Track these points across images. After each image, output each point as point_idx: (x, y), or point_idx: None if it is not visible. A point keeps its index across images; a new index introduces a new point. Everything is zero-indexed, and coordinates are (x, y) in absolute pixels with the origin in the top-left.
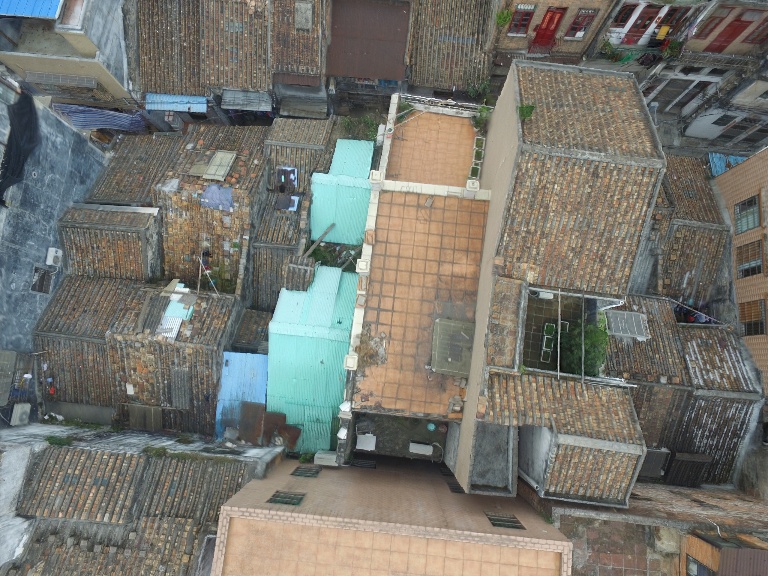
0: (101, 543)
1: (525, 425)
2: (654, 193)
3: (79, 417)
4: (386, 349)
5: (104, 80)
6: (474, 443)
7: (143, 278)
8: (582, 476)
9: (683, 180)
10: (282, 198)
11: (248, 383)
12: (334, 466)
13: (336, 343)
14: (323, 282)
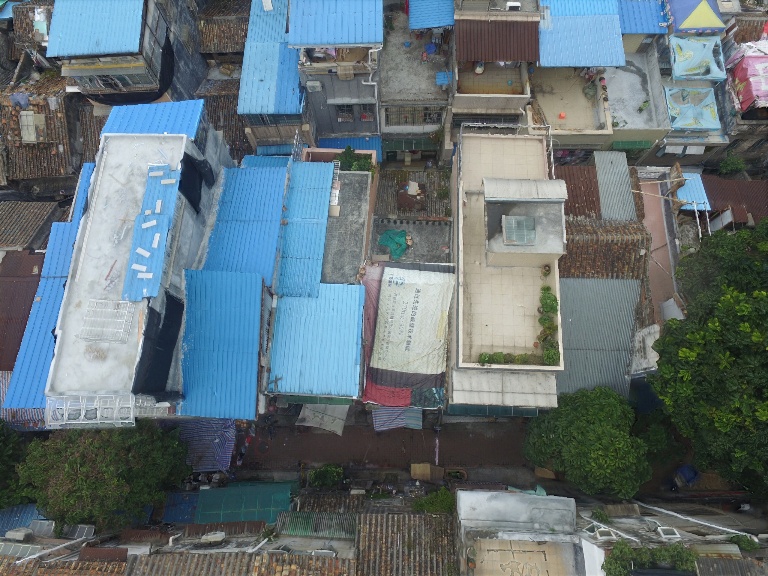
0: None
1: None
2: None
3: None
4: None
5: None
6: None
7: None
8: None
9: None
10: None
11: None
12: None
13: None
14: None
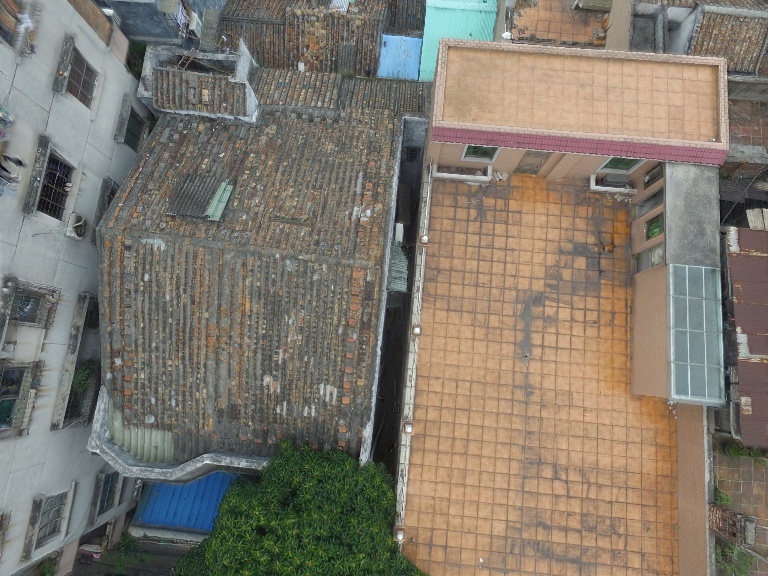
0: None
1: None
2: None
3: None
4: None
5: None
6: (632, 20)
7: None
8: (720, 49)
9: None
10: None
11: (402, 63)
12: None
13: (484, 15)
14: None
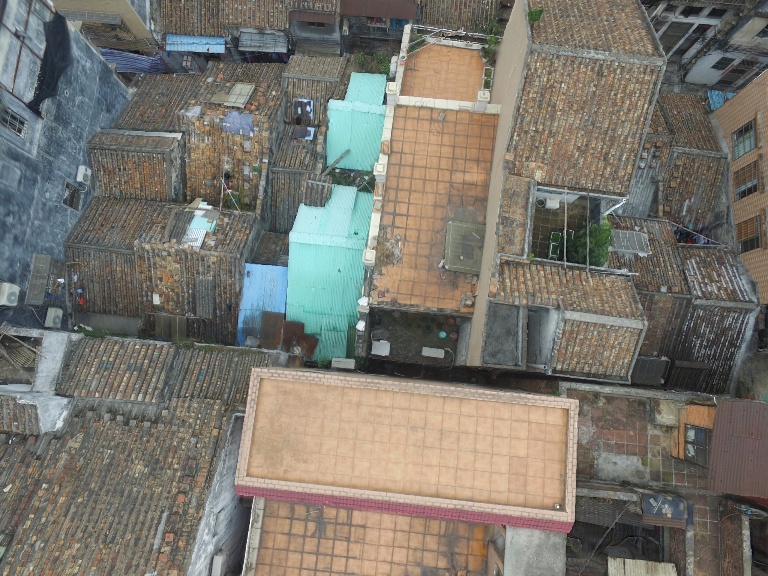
0: (136, 419)
1: (533, 322)
2: (655, 90)
3: (107, 328)
4: (401, 250)
5: (128, 17)
6: (486, 321)
7: (167, 199)
8: (587, 353)
9: (683, 114)
10: (299, 129)
11: (268, 294)
12: (351, 369)
13: (353, 252)
14: (340, 199)
